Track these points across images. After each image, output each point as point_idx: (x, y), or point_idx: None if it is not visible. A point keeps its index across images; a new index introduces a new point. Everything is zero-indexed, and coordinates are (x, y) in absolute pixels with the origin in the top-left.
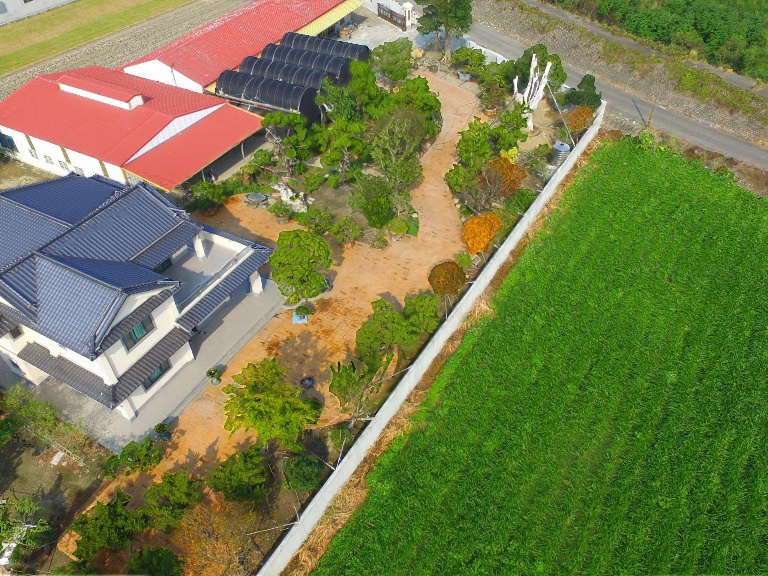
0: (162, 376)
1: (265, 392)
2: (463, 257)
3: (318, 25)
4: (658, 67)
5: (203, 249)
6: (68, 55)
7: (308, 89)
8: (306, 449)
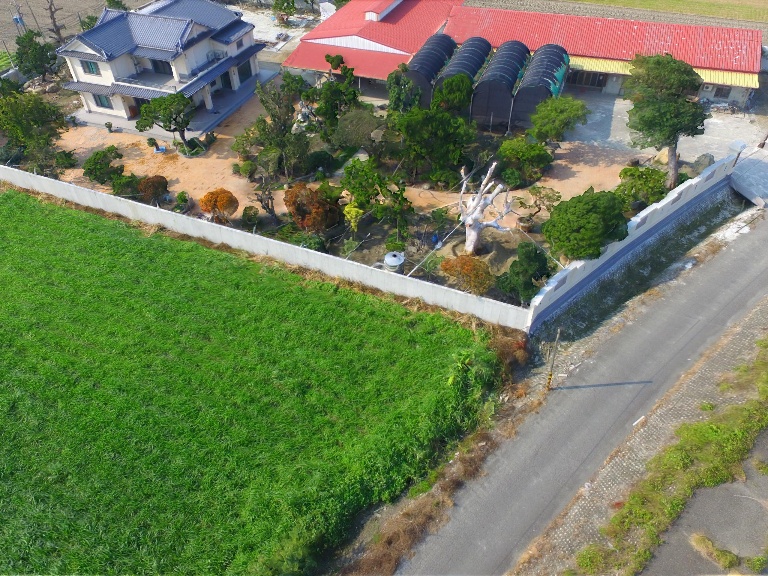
0: (108, 108)
1: None
2: (181, 193)
3: None
4: (748, 393)
5: None
6: (543, 2)
7: (415, 70)
8: None
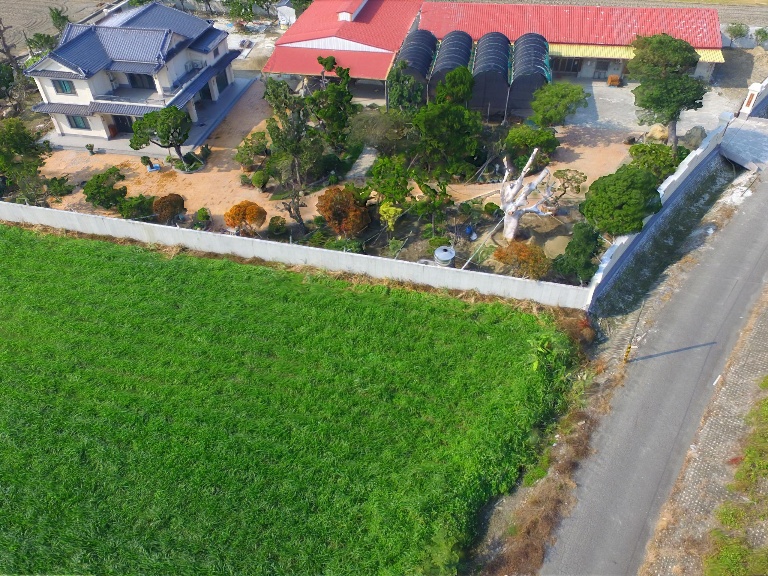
0: (84, 129)
1: (8, 136)
2: (201, 210)
3: (615, 51)
4: None
5: (174, 94)
6: None
7: (410, 67)
8: (31, 199)
